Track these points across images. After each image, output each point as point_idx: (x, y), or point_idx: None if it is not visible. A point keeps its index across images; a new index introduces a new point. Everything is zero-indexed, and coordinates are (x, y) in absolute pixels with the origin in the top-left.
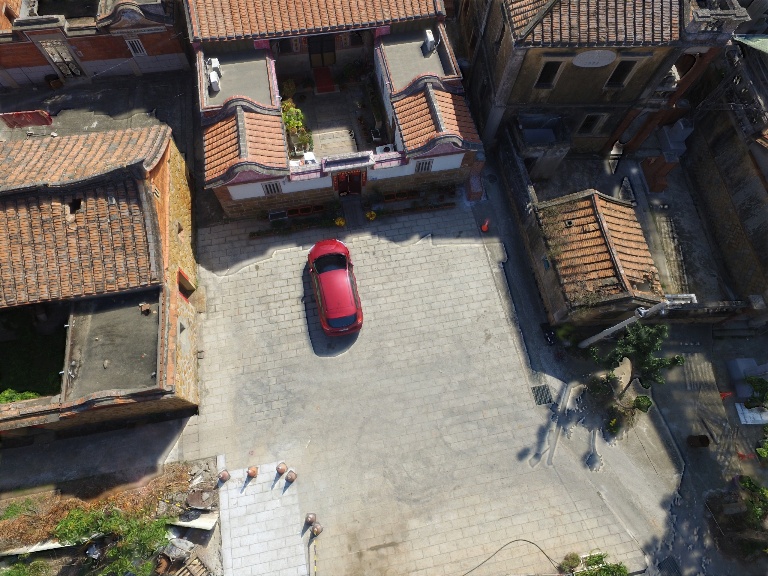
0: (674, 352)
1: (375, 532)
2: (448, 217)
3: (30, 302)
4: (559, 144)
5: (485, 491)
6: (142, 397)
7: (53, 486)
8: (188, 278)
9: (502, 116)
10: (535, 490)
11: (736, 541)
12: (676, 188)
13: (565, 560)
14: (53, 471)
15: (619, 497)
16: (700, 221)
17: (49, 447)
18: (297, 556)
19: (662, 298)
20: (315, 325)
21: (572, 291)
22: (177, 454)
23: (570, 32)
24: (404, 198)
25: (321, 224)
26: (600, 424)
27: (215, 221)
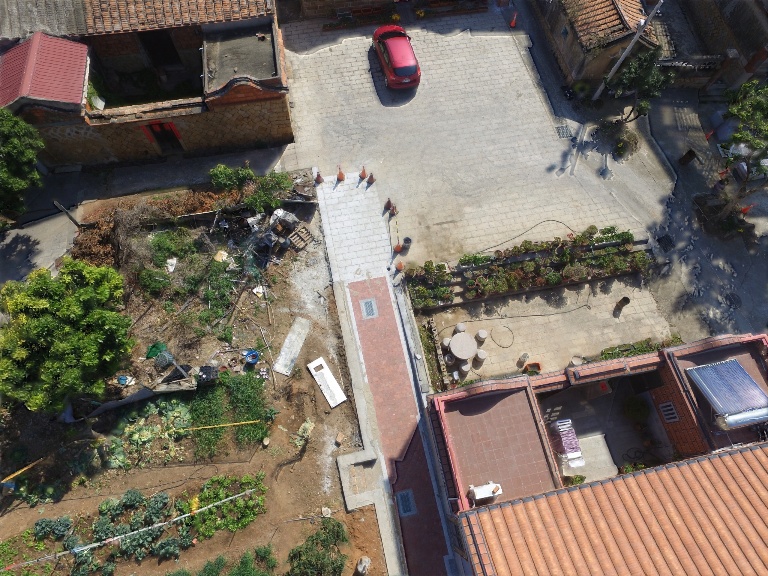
0: (668, 106)
1: (439, 214)
2: (482, 18)
3: (175, 26)
4: None
5: (522, 191)
6: (266, 88)
7: (186, 187)
8: None
9: None
10: (561, 190)
11: (717, 222)
12: (668, 2)
13: (586, 230)
14: (185, 178)
15: (626, 196)
16: (688, 25)
17: (180, 163)
18: (380, 228)
19: None
20: (381, 87)
21: (587, 40)
22: (280, 168)
23: None
24: (446, 4)
25: (380, 20)
26: (610, 150)
27: (293, 19)
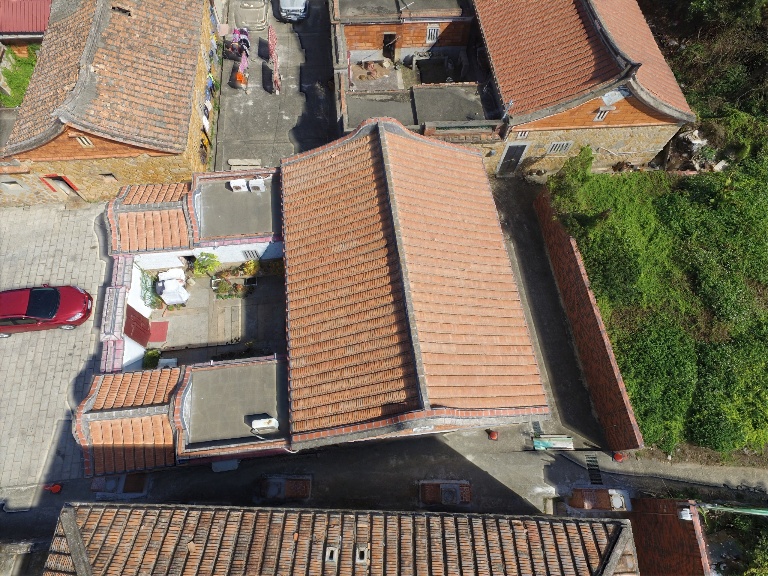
0: None
1: None
2: None
3: None
4: None
5: None
6: None
7: None
8: (80, 190)
9: None
10: None
11: None
12: None
13: None
14: None
15: None
16: None
17: None
18: None
19: None
20: None
21: None
22: None
23: None
24: None
25: None
26: None
27: None
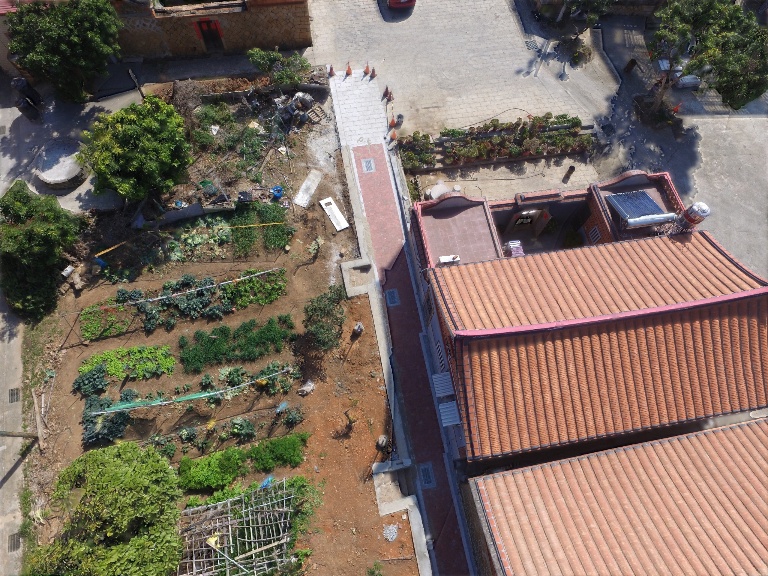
0: (619, 29)
1: (426, 101)
2: None
3: None
4: None
5: (494, 87)
6: None
7: (226, 76)
8: None
9: None
10: (526, 87)
11: (651, 114)
12: None
13: (543, 116)
14: (225, 70)
15: (579, 94)
16: None
17: (221, 59)
18: (379, 109)
19: None
20: (384, 7)
21: None
22: None
23: None
24: None
25: None
26: (568, 59)
27: None
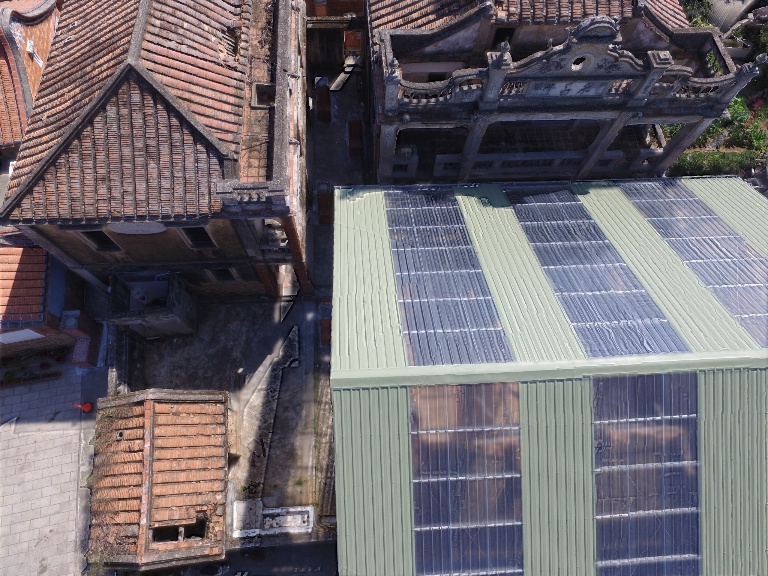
0: None
1: None
2: (47, 392)
3: None
4: (151, 313)
5: None
6: None
7: None
8: None
9: (92, 274)
10: None
11: None
12: None
13: None
14: None
15: None
16: None
17: None
18: None
19: (210, 547)
20: None
21: (95, 538)
22: None
23: (71, 205)
24: None
25: None
26: None
27: None
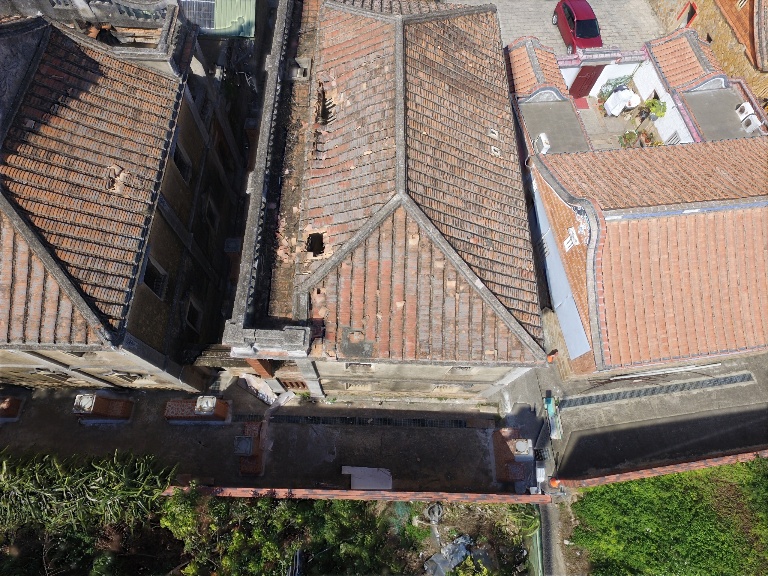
0: None
1: None
2: None
3: None
4: None
5: None
6: None
7: None
8: None
9: None
10: None
11: None
12: None
13: None
14: None
15: None
16: None
17: None
18: None
19: None
20: None
21: None
22: None
23: None
24: None
25: None
26: None
27: None
